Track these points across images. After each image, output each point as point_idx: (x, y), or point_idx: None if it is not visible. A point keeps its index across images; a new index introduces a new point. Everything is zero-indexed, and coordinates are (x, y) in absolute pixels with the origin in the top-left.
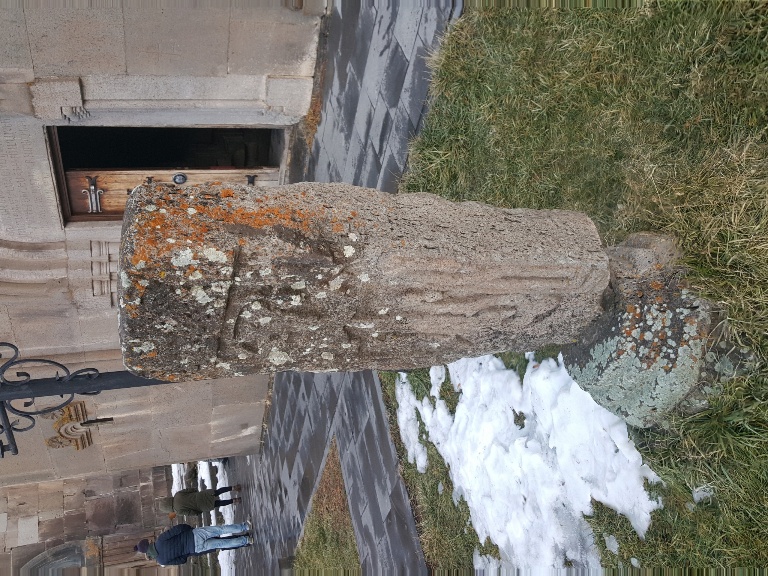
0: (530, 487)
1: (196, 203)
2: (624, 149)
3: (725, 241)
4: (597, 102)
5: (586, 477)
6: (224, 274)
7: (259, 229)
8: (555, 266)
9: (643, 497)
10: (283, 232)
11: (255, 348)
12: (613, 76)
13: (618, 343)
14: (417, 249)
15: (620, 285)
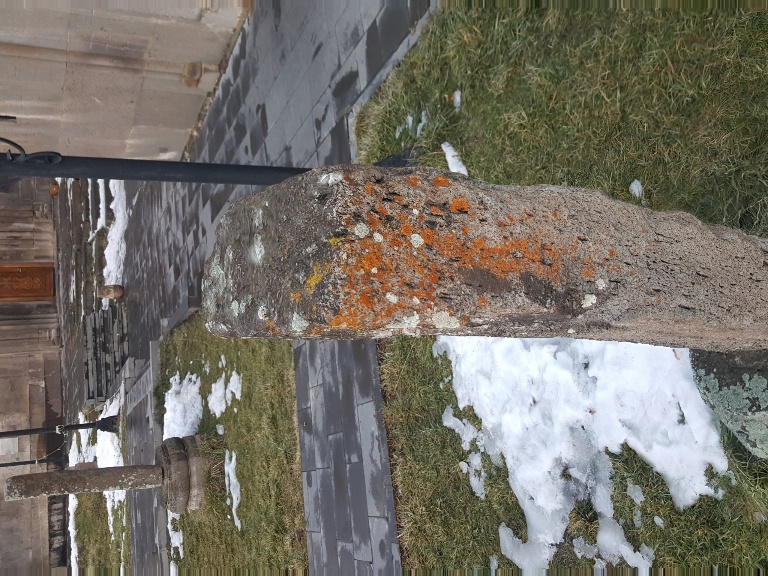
0: (546, 395)
1: (422, 225)
2: None
3: None
4: None
5: (625, 421)
6: None
7: (503, 279)
8: None
9: (700, 480)
10: (531, 285)
11: None
12: None
13: None
14: (671, 310)
15: None
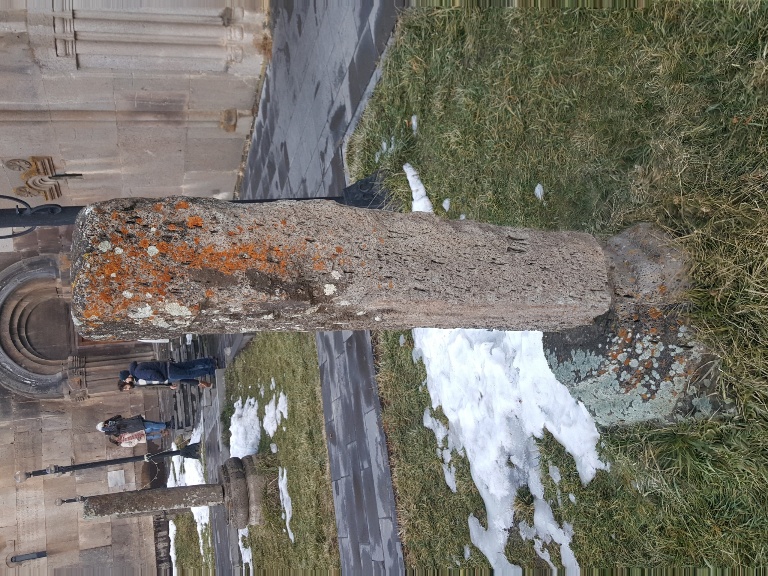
0: (488, 389)
1: (158, 239)
2: (657, 106)
3: (739, 289)
4: (640, 30)
5: (543, 407)
6: (188, 318)
7: (230, 276)
8: (552, 305)
9: (593, 455)
10: (257, 279)
11: None
12: (665, 11)
13: (601, 364)
14: (406, 292)
15: (617, 304)
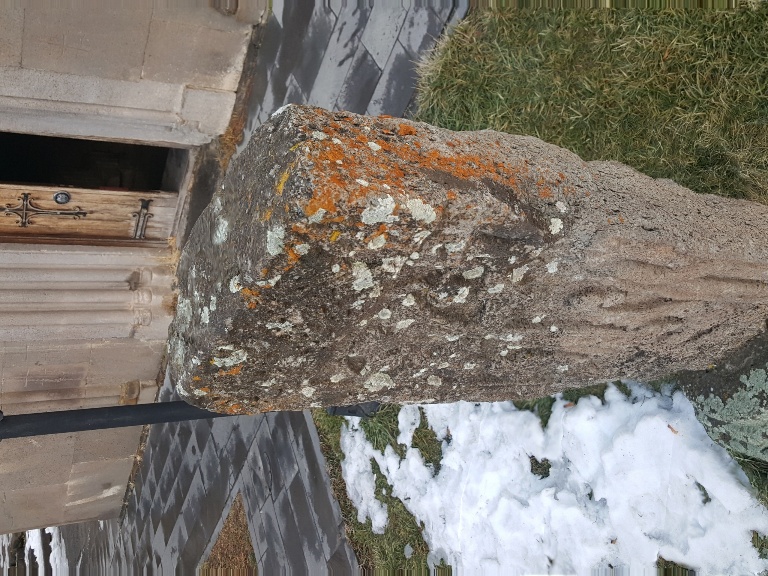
0: (561, 546)
1: (376, 136)
2: (716, 155)
3: None
4: (668, 106)
5: (650, 532)
6: (414, 243)
7: (466, 180)
8: (764, 264)
9: (751, 554)
10: (495, 188)
11: (356, 366)
12: (697, 75)
13: None
14: (637, 228)
15: None
